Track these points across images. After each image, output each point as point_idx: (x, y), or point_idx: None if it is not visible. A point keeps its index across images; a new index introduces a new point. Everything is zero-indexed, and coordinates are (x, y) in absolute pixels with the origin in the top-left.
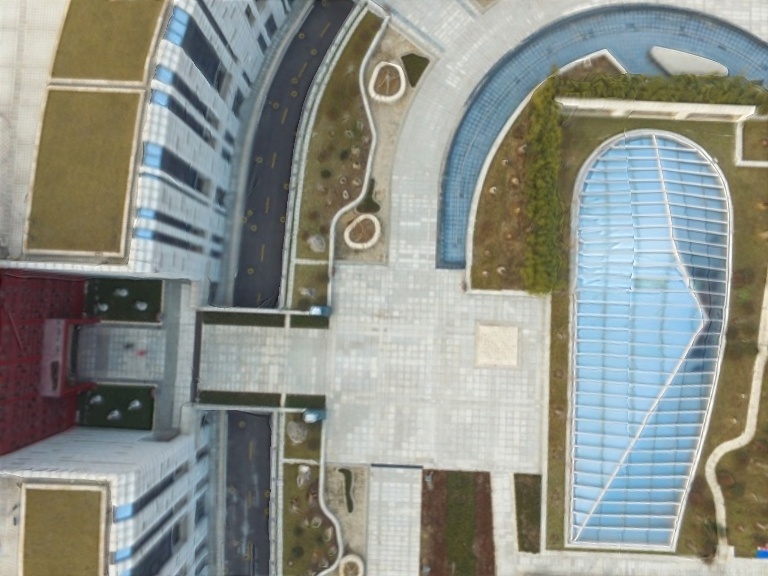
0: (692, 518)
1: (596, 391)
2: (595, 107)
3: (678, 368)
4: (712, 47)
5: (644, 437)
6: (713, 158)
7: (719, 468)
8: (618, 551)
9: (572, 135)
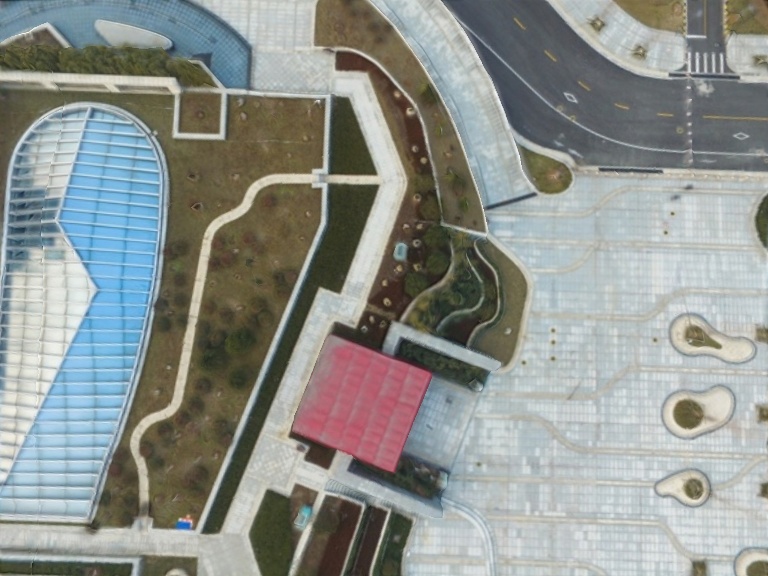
0: (111, 489)
1: (15, 363)
2: (14, 79)
3: (73, 338)
4: (162, 20)
5: (55, 408)
6: (152, 131)
7: (143, 439)
8: (36, 523)
9: (11, 108)
